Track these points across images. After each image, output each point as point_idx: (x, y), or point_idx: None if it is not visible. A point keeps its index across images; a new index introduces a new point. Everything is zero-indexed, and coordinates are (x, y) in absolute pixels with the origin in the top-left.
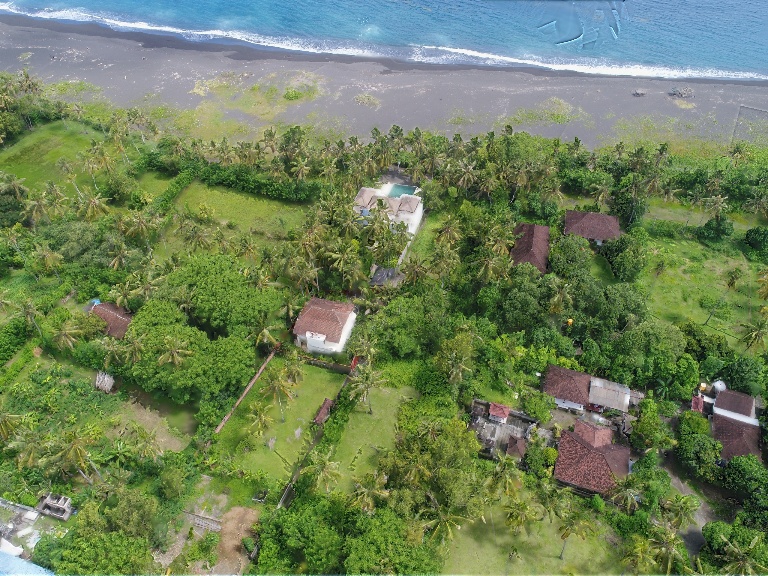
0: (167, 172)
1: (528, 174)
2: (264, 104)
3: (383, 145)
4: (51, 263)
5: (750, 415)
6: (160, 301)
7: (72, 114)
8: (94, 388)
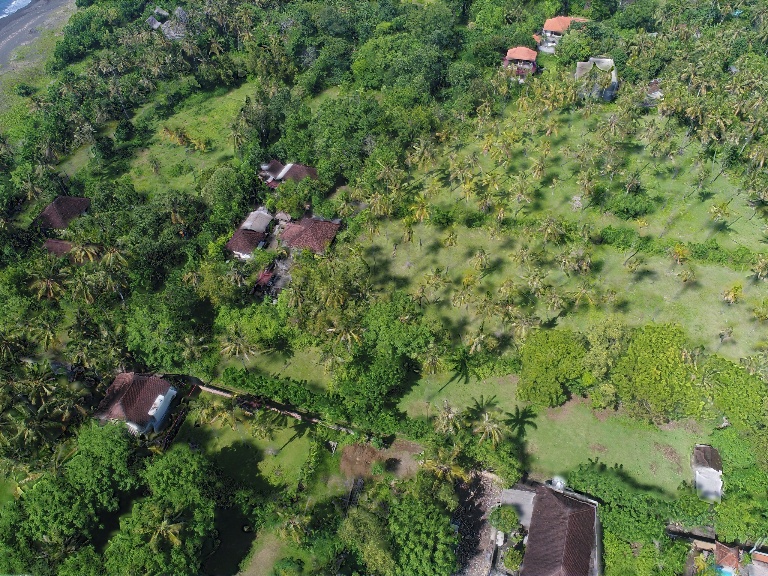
0: None
1: None
2: None
3: None
4: None
5: (284, 166)
6: None
7: None
8: None
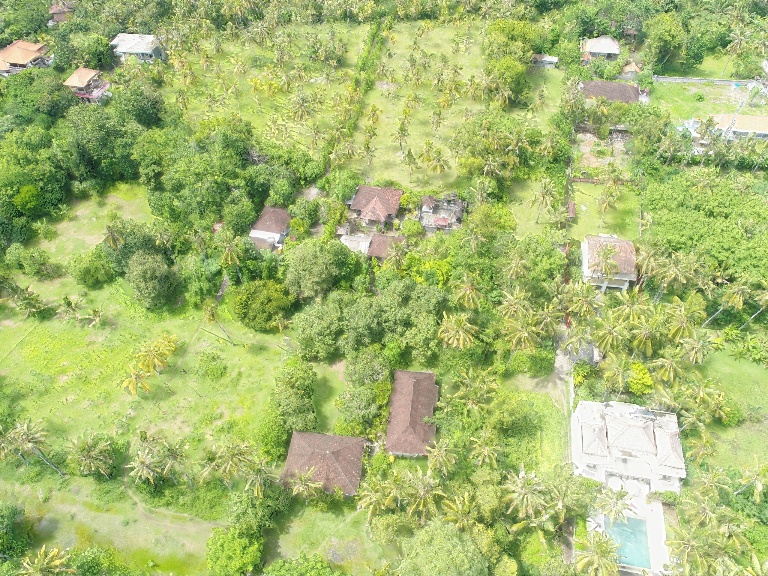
0: None
1: None
2: None
3: None
4: None
5: None
6: (764, 222)
7: None
8: None
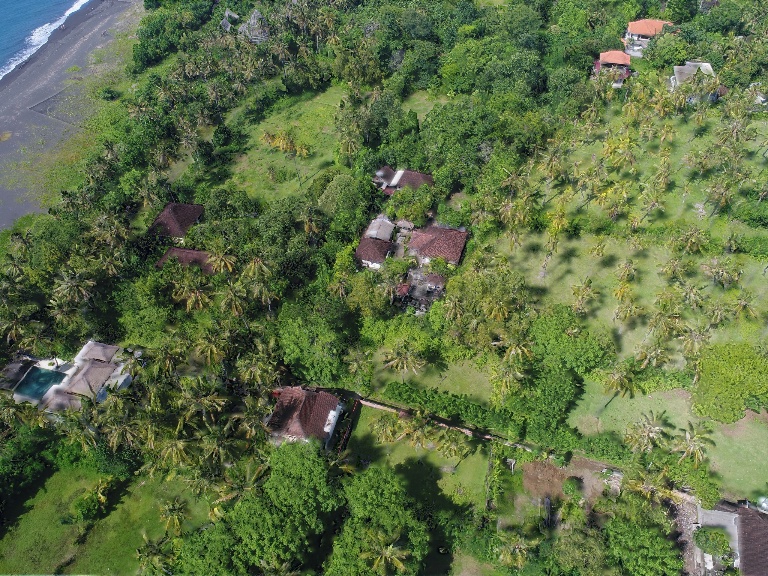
0: None
1: None
2: None
3: None
4: None
5: (395, 173)
6: None
7: None
8: None
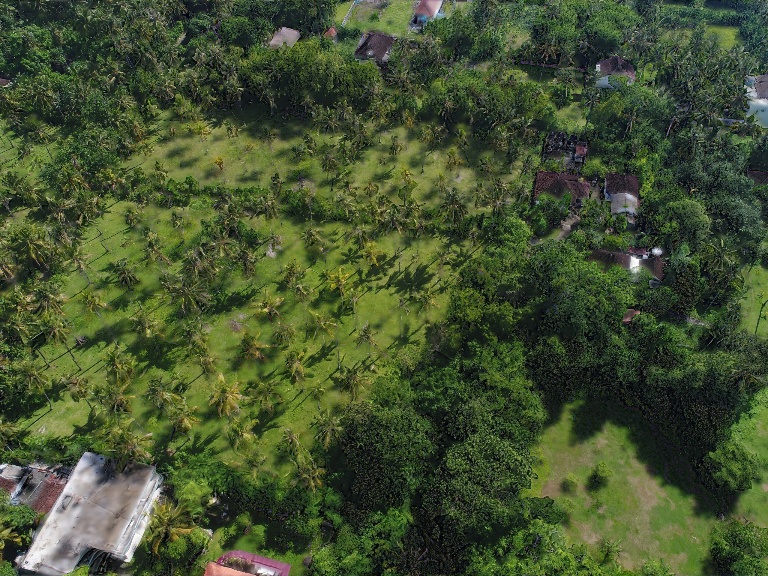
0: None
1: None
2: None
3: None
4: None
5: None
6: (588, 7)
7: None
8: None
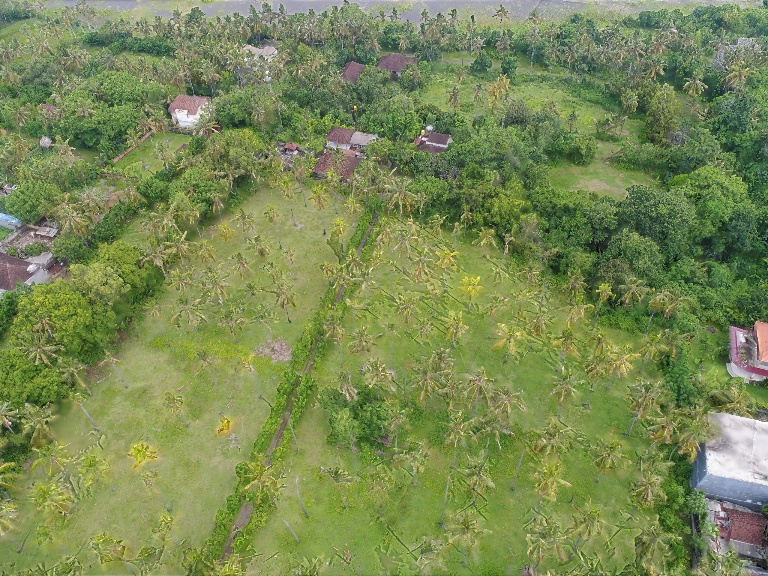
0: (104, 45)
1: (352, 29)
2: (185, 6)
3: (254, 15)
4: (13, 79)
5: (446, 144)
6: None
7: (37, 13)
8: (39, 147)
